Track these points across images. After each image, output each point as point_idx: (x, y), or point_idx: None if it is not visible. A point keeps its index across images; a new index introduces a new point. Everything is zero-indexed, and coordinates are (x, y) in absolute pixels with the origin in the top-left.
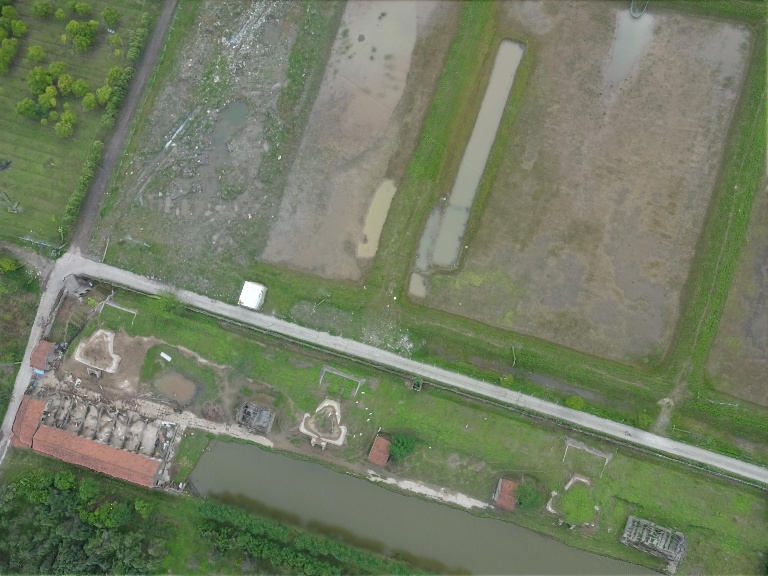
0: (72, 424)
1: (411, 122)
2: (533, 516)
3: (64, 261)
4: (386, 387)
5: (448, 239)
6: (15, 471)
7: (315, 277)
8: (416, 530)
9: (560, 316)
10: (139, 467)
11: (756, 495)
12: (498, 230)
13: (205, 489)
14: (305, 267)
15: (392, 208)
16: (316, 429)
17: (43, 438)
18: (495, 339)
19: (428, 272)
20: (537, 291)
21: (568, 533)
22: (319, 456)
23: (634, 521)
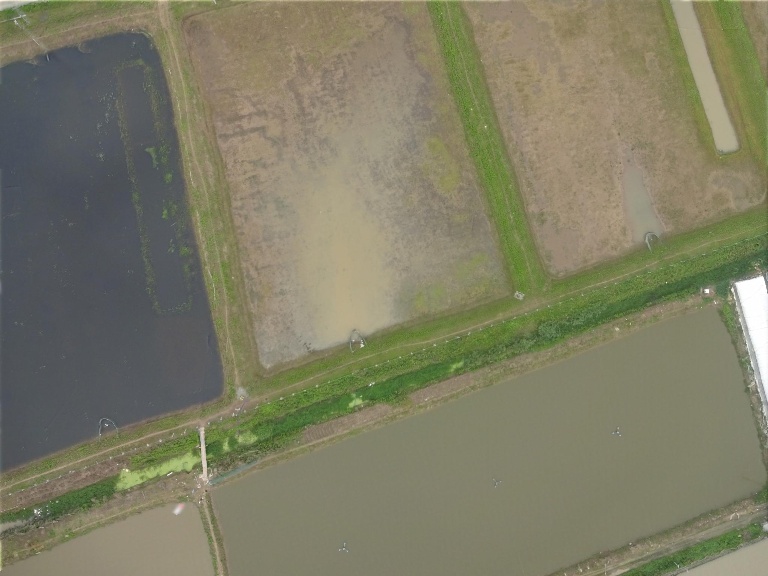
0: None
1: (762, 38)
2: None
3: None
4: None
5: None
6: None
7: None
8: None
9: None
10: None
11: None
12: None
13: None
14: None
15: None
16: None
17: None
18: None
19: None
20: None
21: None
22: None
23: None
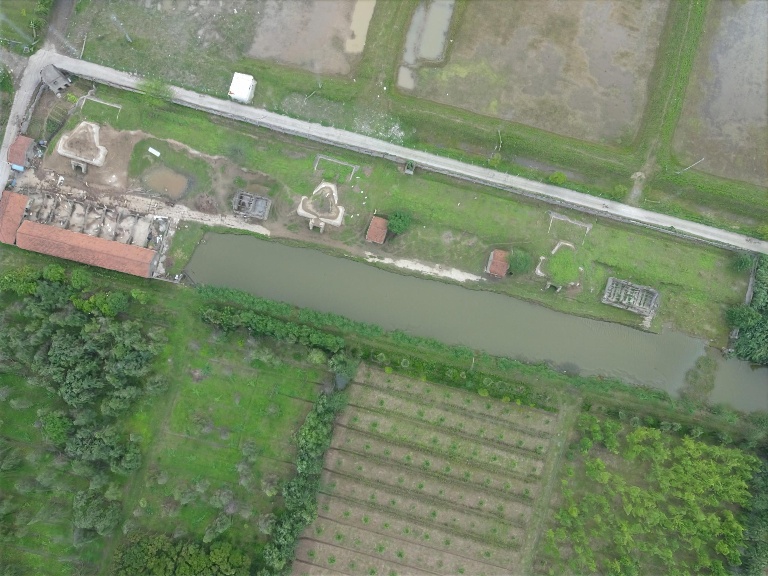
0: (57, 222)
1: None
2: (523, 284)
3: (38, 58)
4: (380, 172)
5: (433, 33)
6: None
7: (304, 71)
8: (414, 305)
9: (541, 103)
10: (134, 255)
11: (717, 254)
12: (481, 25)
13: (203, 278)
14: (294, 62)
15: (378, 4)
16: (314, 209)
17: (28, 232)
18: (482, 124)
19: (415, 65)
20: (519, 81)
21: (555, 298)
22: (317, 240)
23: (613, 283)
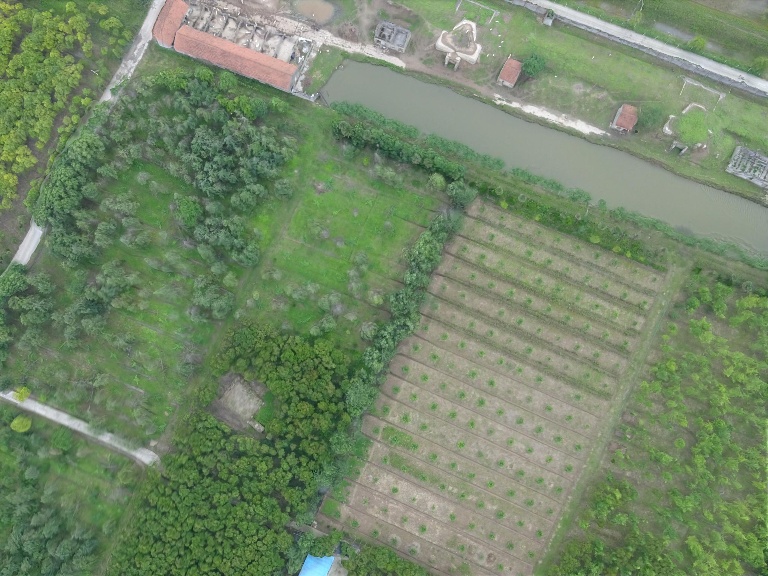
0: (210, 33)
1: None
2: (647, 142)
3: None
4: (519, 19)
5: None
6: (152, 70)
7: None
8: (535, 149)
9: None
10: (279, 66)
11: None
12: None
13: (337, 99)
14: None
15: None
16: (453, 43)
17: (186, 34)
18: None
19: None
20: None
21: (678, 160)
22: (449, 77)
23: (739, 154)
